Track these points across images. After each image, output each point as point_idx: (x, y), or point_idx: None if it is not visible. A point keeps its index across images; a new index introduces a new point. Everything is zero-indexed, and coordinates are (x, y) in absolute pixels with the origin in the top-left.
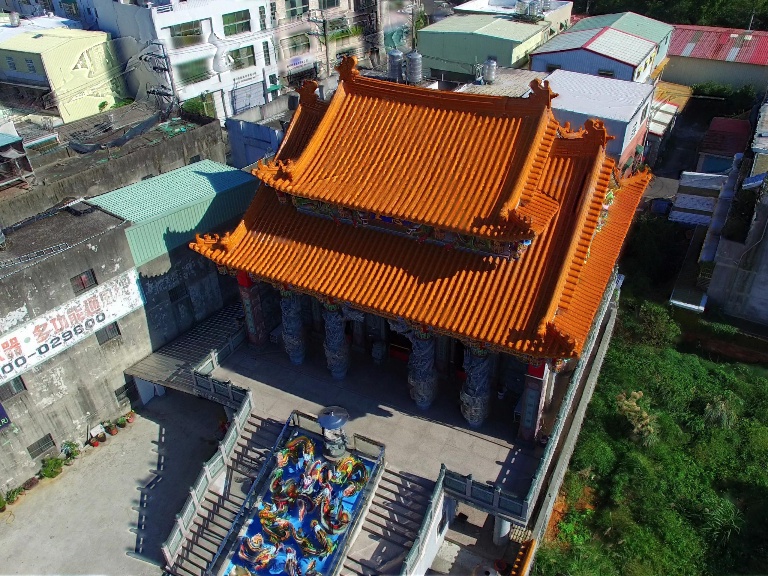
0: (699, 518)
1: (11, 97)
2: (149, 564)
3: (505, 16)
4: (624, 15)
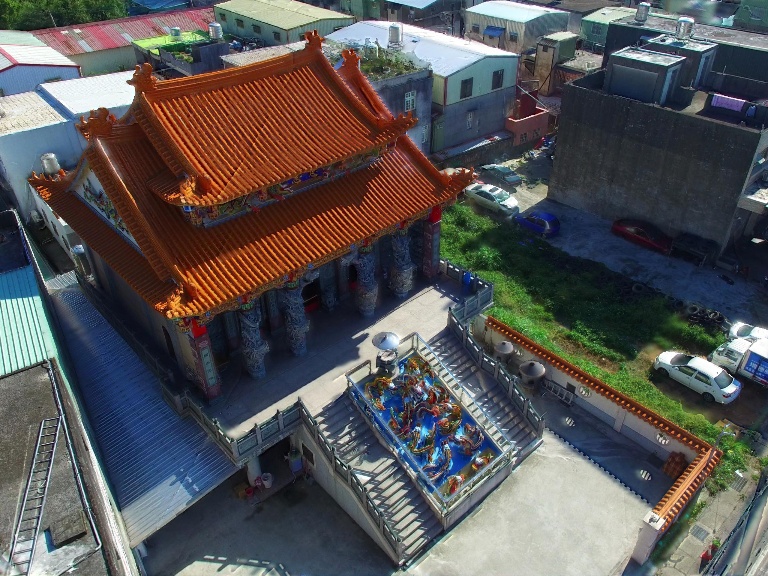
0: (483, 265)
1: None
2: None
3: None
4: None
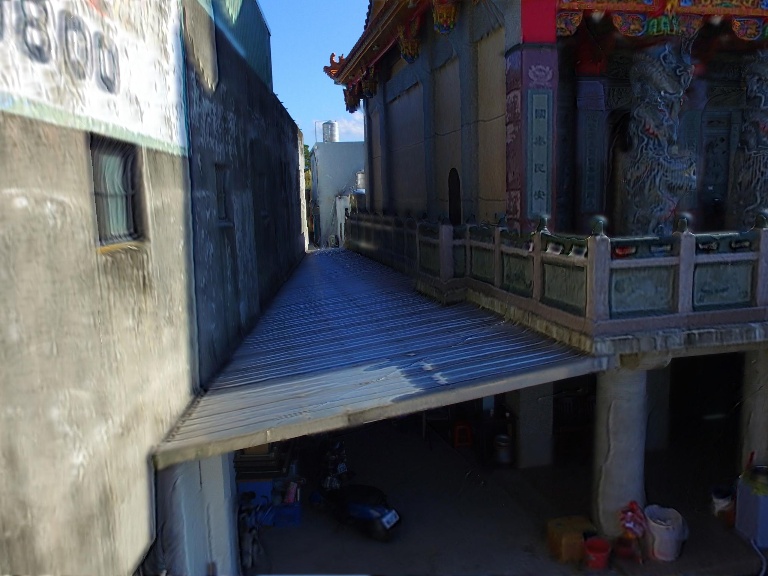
0: None
1: None
2: None
3: None
4: None
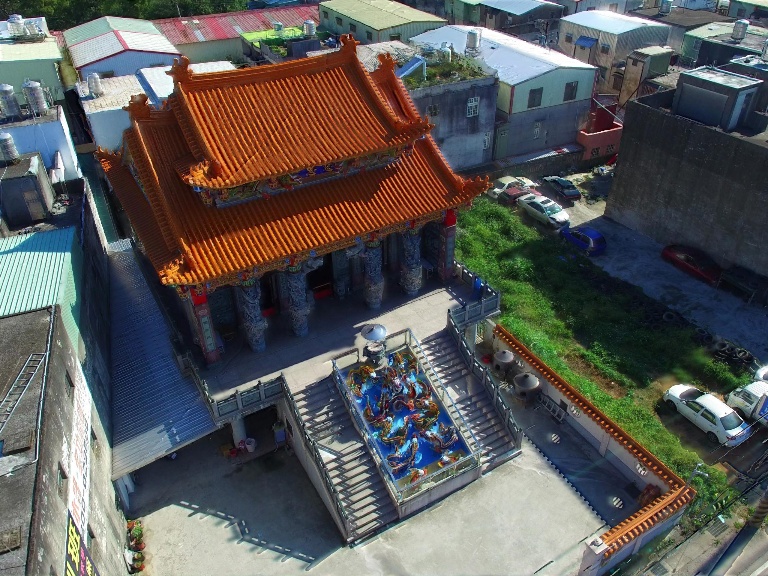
0: (514, 275)
1: None
2: (332, 555)
3: (0, 41)
4: (107, 19)
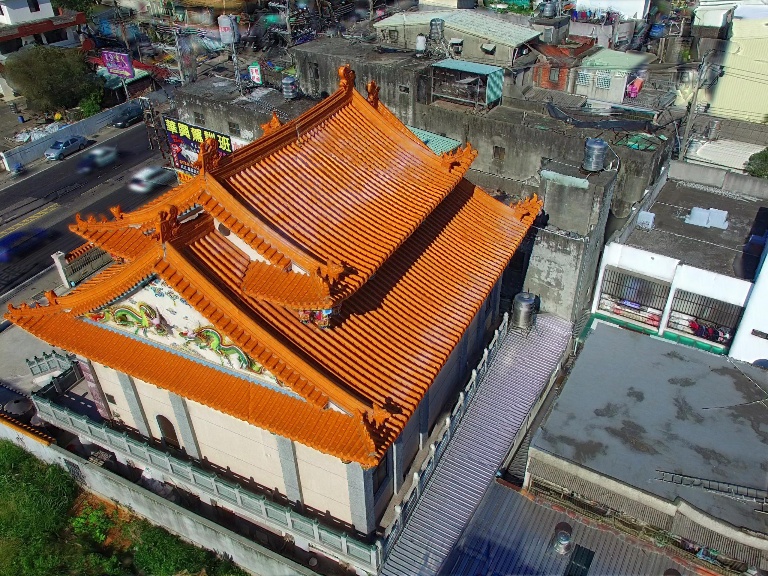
0: None
1: (551, 48)
2: None
3: None
4: None
